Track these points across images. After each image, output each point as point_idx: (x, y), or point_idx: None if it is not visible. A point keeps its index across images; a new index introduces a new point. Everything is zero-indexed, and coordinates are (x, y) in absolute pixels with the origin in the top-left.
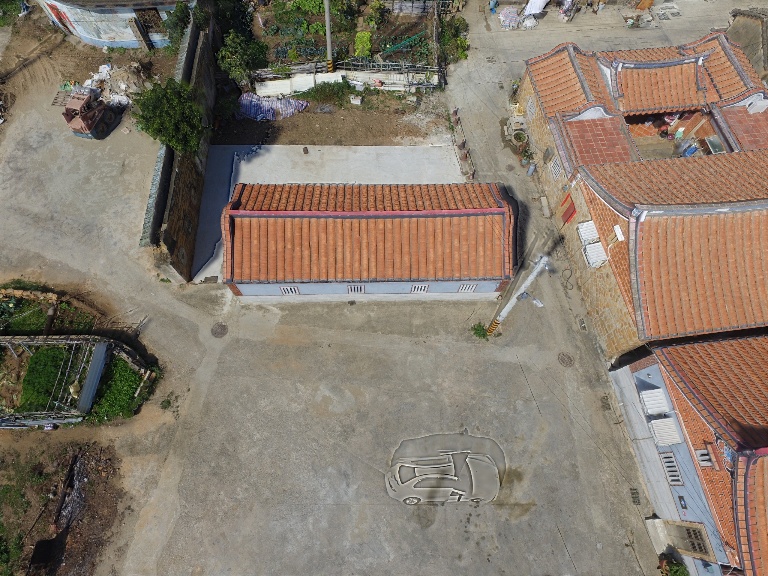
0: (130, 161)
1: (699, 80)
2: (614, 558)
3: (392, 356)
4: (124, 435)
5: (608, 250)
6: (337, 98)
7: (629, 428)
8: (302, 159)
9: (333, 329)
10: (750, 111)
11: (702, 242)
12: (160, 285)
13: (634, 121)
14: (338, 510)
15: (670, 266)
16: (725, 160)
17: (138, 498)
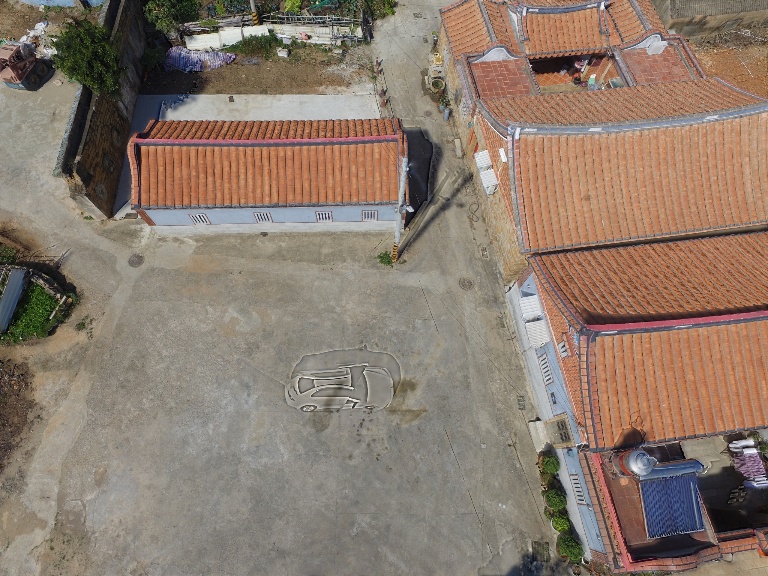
0: (61, 110)
1: (602, 24)
2: (496, 456)
3: (300, 281)
4: (38, 354)
5: (498, 175)
6: (264, 51)
7: (520, 342)
8: (227, 107)
9: (245, 258)
10: (649, 52)
11: (579, 161)
12: (83, 222)
13: (550, 70)
14: (238, 417)
15: (548, 183)
16: (615, 93)
17: (48, 408)
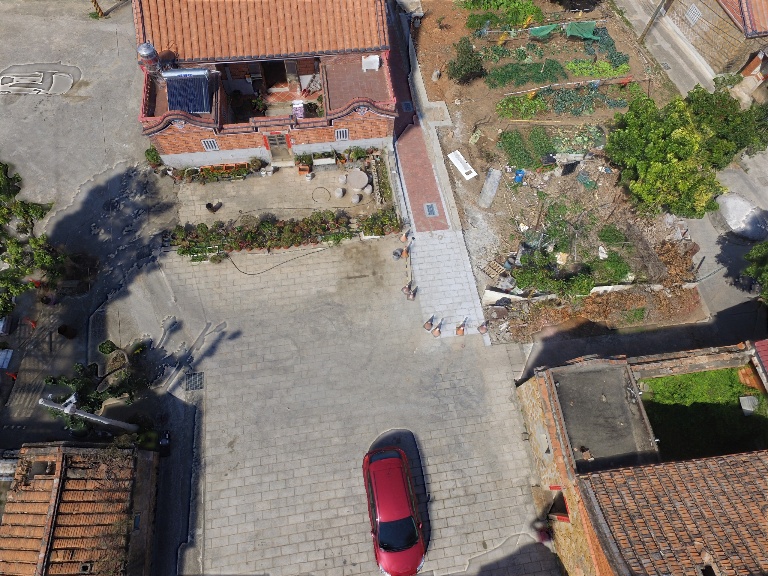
0: None
1: None
2: (133, 121)
3: (24, 25)
4: None
5: None
6: None
7: None
8: None
9: None
10: None
11: None
12: None
13: None
14: None
15: None
16: None
17: None
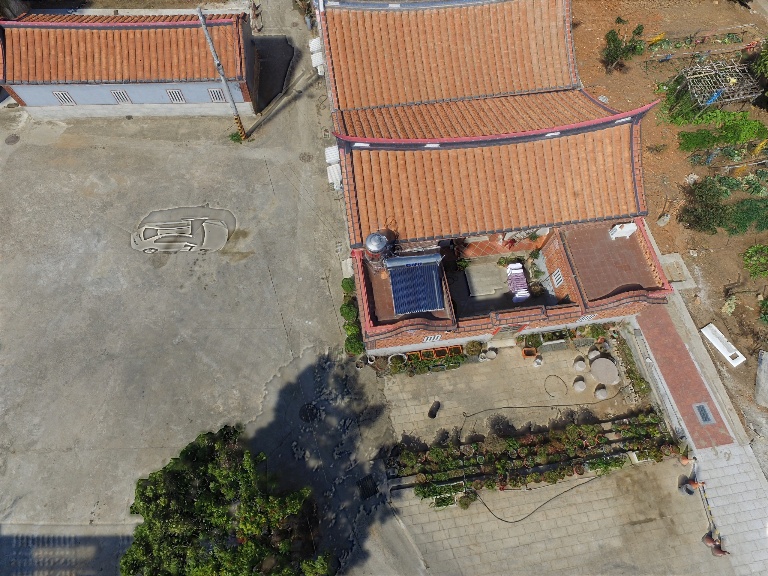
0: None
1: None
2: (310, 286)
3: (156, 155)
4: None
5: None
6: None
7: None
8: None
9: (109, 136)
10: None
11: (383, 35)
12: None
13: None
14: (86, 257)
15: (355, 53)
16: None
17: None
